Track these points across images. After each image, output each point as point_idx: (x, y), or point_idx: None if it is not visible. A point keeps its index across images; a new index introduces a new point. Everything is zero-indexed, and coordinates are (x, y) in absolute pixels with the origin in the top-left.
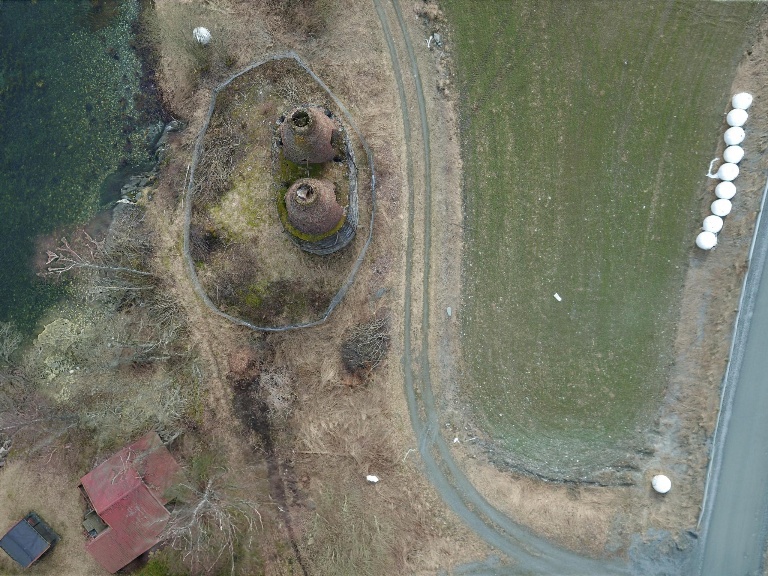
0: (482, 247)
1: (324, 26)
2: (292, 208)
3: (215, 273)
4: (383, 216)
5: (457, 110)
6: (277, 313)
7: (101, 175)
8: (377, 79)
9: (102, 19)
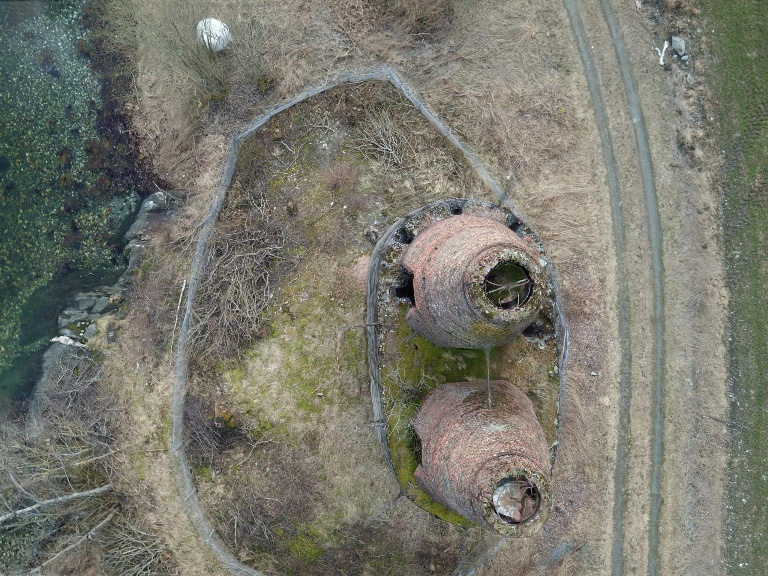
0: (767, 466)
1: (449, 20)
2: (454, 505)
3: (231, 490)
4: (573, 404)
5: (718, 190)
6: (350, 575)
7: (23, 289)
8: (558, 125)
9: (29, 2)
